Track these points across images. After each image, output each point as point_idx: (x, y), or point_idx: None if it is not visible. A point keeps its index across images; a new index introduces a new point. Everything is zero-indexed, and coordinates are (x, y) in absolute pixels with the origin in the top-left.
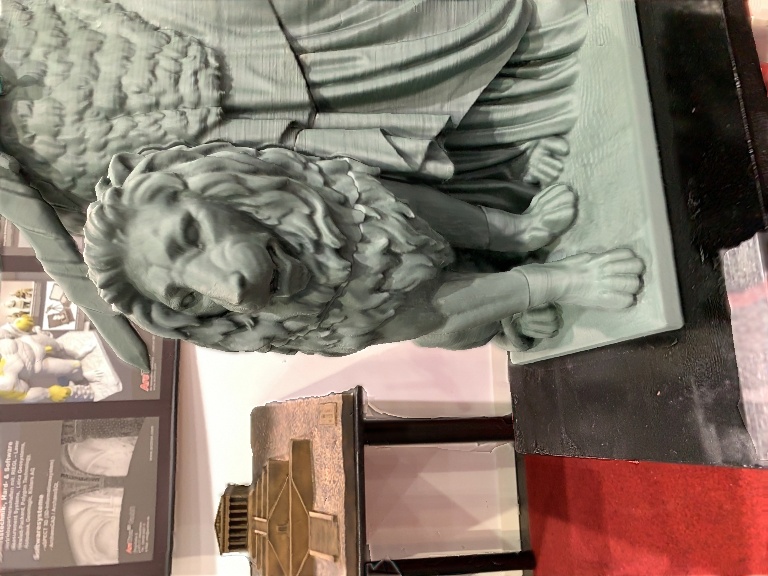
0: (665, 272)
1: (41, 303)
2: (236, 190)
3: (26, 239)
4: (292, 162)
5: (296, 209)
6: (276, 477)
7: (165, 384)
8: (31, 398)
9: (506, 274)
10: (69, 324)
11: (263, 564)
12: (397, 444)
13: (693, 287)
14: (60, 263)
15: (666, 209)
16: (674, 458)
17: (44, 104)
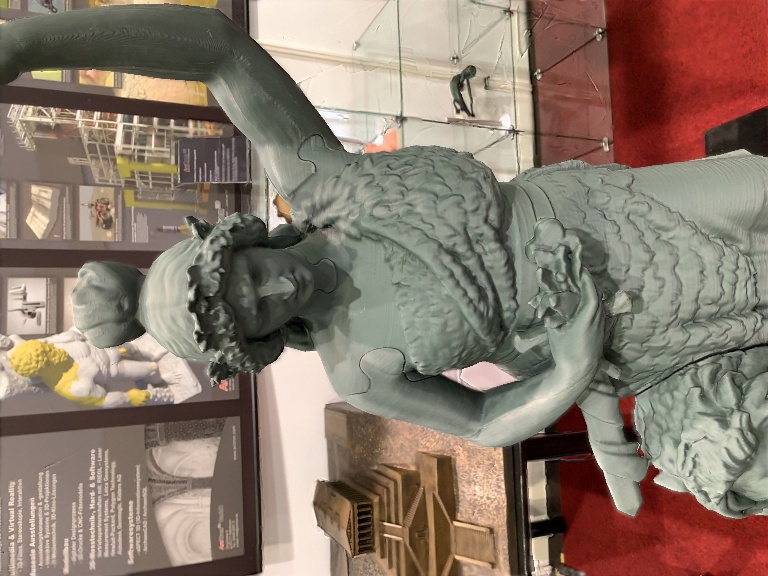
0: None
1: None
2: None
3: (87, 231)
4: None
5: None
6: (408, 487)
7: (243, 383)
8: (109, 403)
9: None
10: None
11: (398, 565)
12: (532, 459)
13: None
14: (616, 445)
15: None
16: None
17: (644, 318)
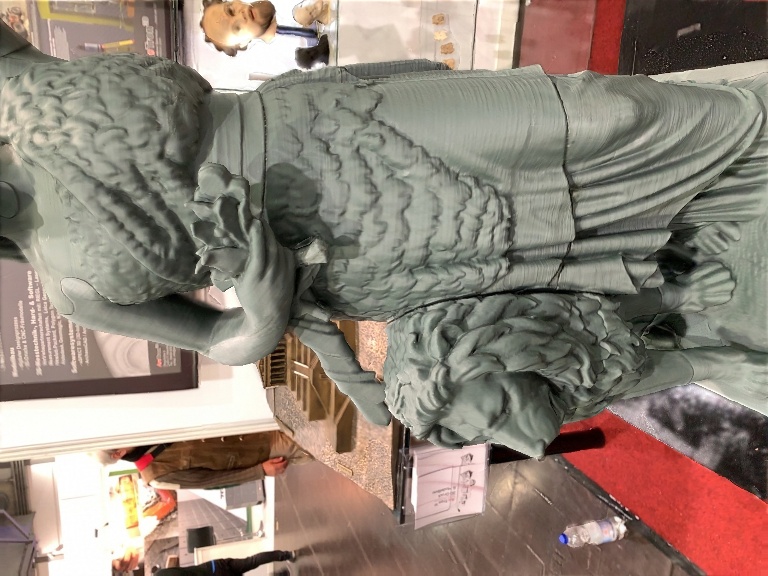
0: None
1: None
2: (540, 368)
3: None
4: (563, 312)
5: (571, 367)
6: None
7: None
8: None
9: (676, 362)
10: None
11: (304, 399)
12: None
13: None
14: (345, 374)
15: None
16: (755, 492)
17: (360, 264)
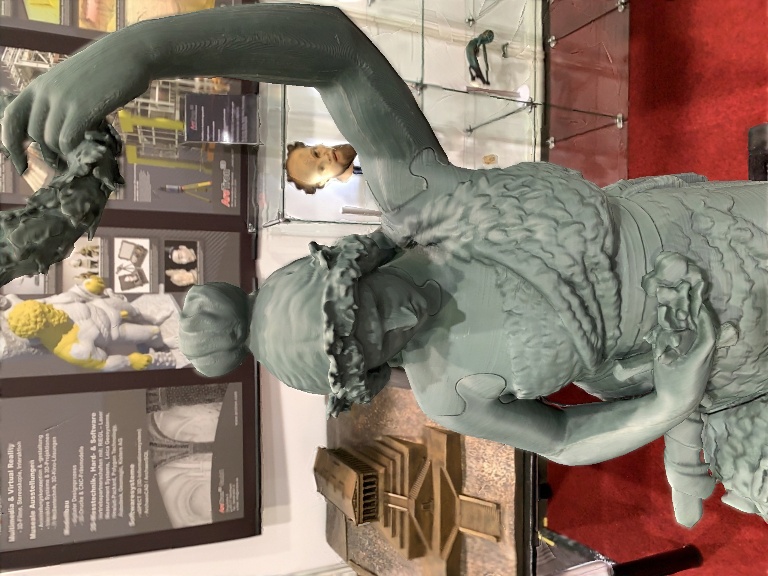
0: None
1: (110, 262)
2: None
3: None
4: None
5: None
6: (415, 460)
7: None
8: (110, 367)
9: None
10: (143, 286)
11: (401, 534)
12: None
13: None
14: (692, 467)
15: None
16: None
17: (740, 348)
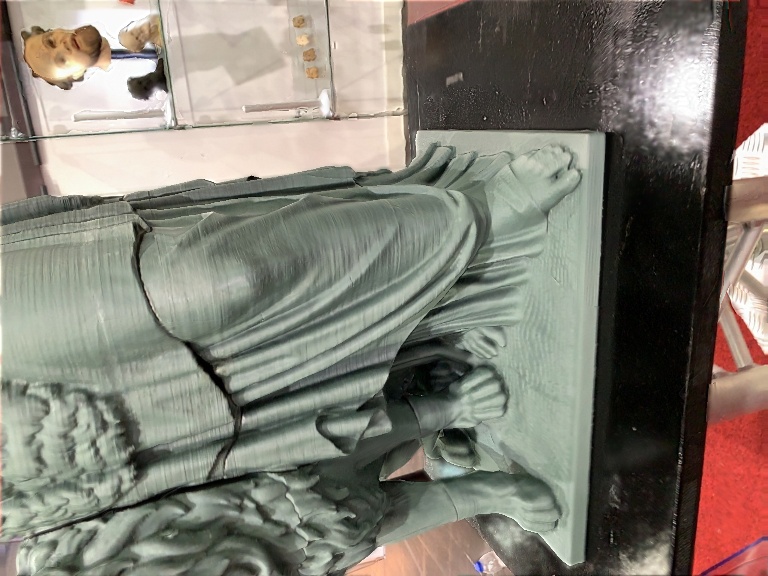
0: (578, 525)
1: None
2: None
3: None
4: (227, 512)
5: None
6: None
7: None
8: None
9: (437, 501)
10: None
11: None
12: None
13: (598, 549)
14: None
15: (589, 469)
16: None
17: None
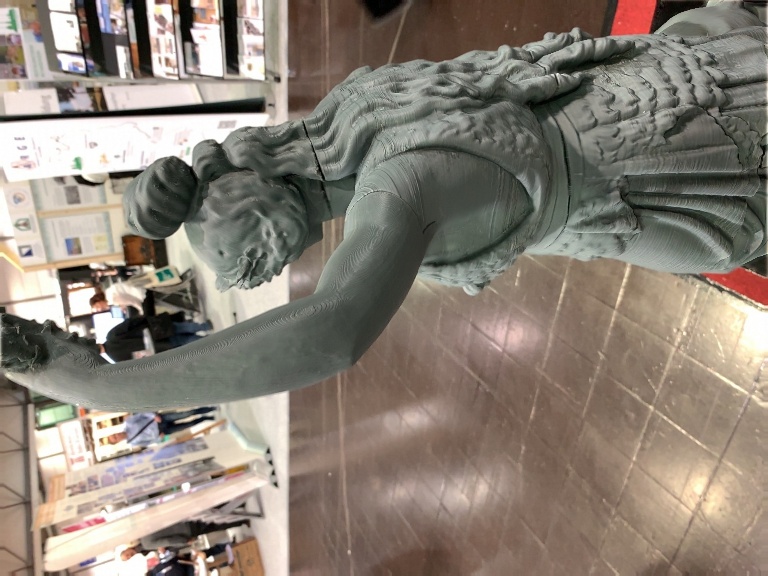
0: None
1: None
2: None
3: None
4: None
5: None
6: None
7: None
8: None
9: None
10: None
11: None
12: None
13: None
14: None
15: None
16: None
17: None
